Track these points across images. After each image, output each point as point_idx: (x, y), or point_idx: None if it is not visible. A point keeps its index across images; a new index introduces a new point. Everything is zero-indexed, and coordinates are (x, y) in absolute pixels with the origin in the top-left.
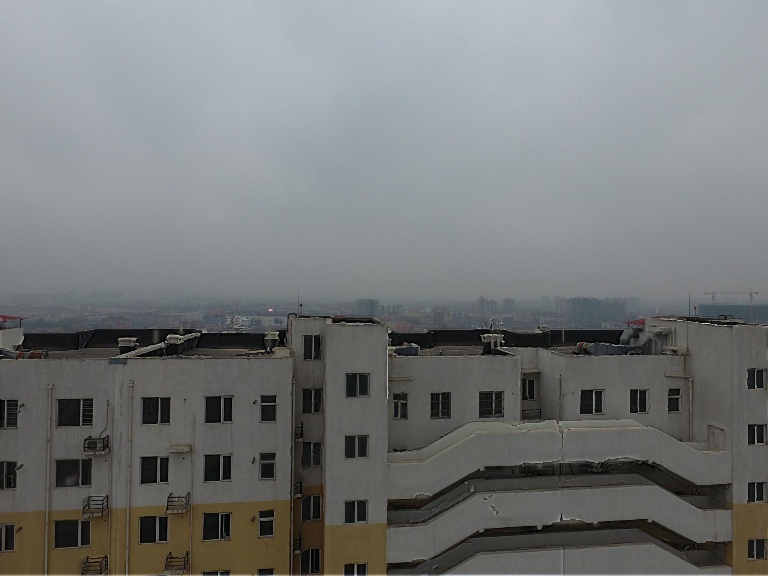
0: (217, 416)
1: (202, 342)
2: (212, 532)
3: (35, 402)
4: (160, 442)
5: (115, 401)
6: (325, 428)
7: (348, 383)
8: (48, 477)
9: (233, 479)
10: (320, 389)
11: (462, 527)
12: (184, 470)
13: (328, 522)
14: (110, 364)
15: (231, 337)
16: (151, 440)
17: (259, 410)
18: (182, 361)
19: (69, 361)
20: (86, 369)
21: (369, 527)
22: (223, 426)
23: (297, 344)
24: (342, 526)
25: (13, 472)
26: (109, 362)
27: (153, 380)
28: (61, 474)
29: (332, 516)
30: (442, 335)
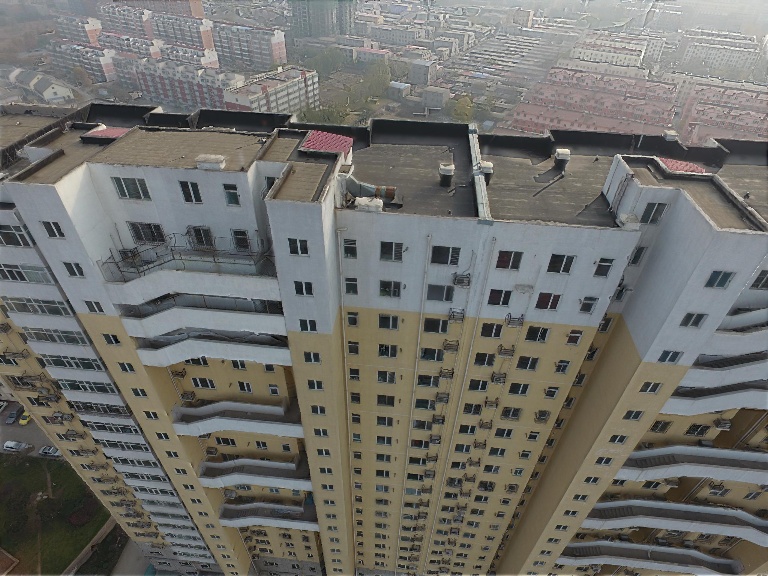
0: (558, 268)
1: (479, 144)
2: (533, 337)
3: (416, 246)
4: (508, 282)
5: (478, 251)
6: (673, 306)
7: (711, 278)
8: (424, 294)
9: (559, 310)
10: (644, 247)
11: (751, 376)
12: (523, 301)
13: (645, 360)
14: (478, 224)
15: (506, 140)
16: (502, 280)
17: (595, 268)
18: (540, 227)
19: (445, 219)
20: (458, 226)
21: (676, 367)
22: (561, 276)
23: (639, 210)
24: (655, 363)
25: (397, 287)
26: (478, 222)
27: (512, 239)
28: (430, 292)
29: (650, 357)
30: (729, 146)
